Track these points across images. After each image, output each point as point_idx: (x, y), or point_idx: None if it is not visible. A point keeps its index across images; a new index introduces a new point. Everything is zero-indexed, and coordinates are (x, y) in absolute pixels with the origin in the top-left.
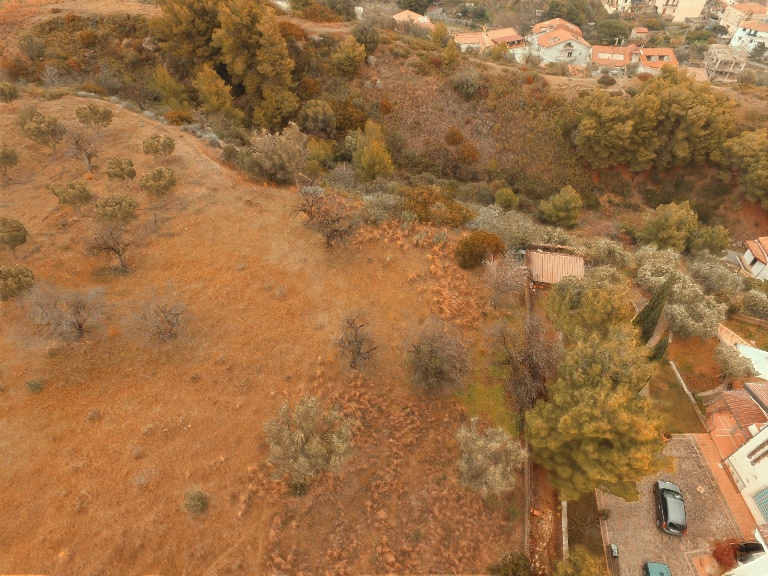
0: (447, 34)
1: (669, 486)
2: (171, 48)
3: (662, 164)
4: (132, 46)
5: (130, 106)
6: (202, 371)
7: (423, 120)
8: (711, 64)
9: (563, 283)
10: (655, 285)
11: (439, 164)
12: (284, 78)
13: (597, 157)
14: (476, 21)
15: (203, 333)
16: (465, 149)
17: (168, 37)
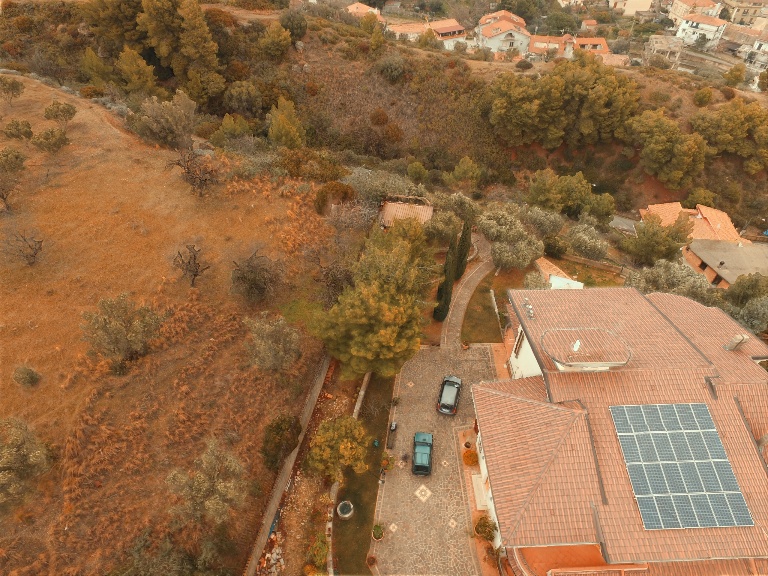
0: (376, 22)
1: (453, 379)
2: (102, 32)
3: (572, 142)
4: (67, 31)
5: (49, 82)
6: (58, 287)
7: (349, 102)
8: (649, 54)
9: None
10: (487, 227)
11: (361, 142)
12: (209, 60)
13: (512, 135)
14: (432, 14)
15: (67, 260)
16: (389, 129)
17: (98, 22)
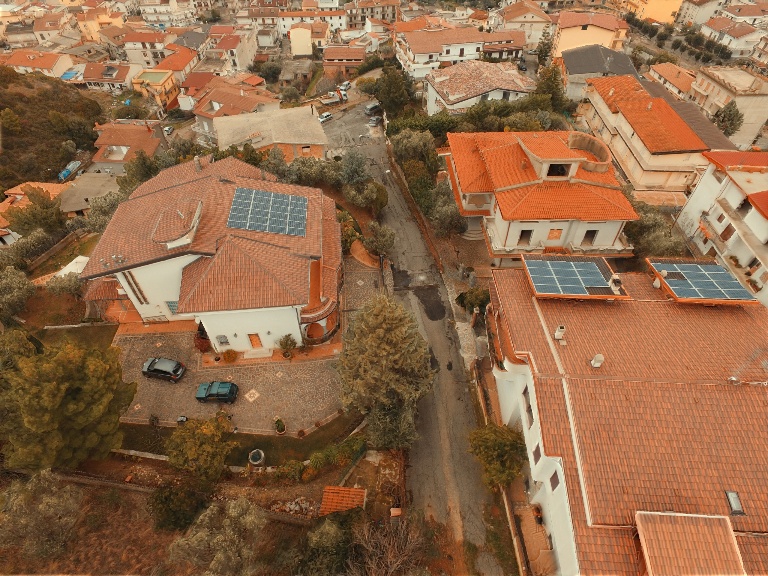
0: None
1: (147, 364)
2: None
3: None
4: None
5: None
6: None
7: None
8: None
9: None
10: None
11: None
12: None
13: None
14: None
15: None
16: None
17: None
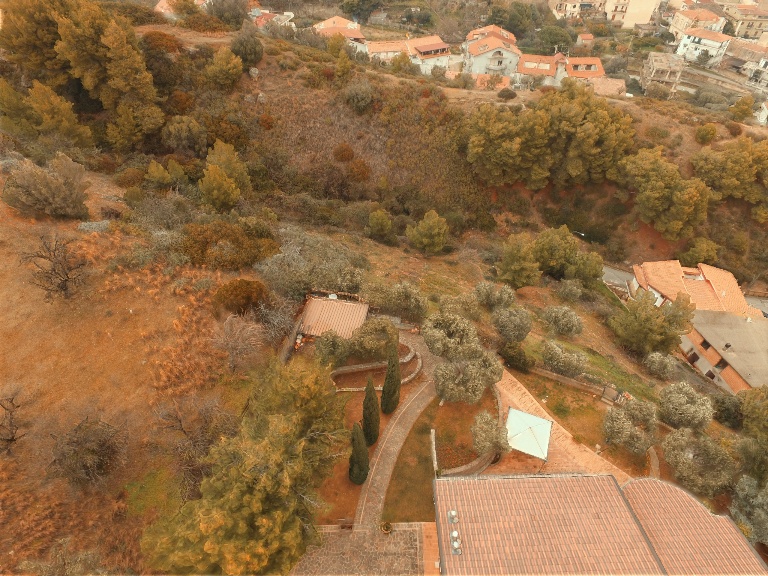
0: (344, 44)
1: None
2: (20, 60)
3: (559, 182)
4: None
5: None
6: None
7: (310, 135)
8: (648, 73)
9: (321, 339)
10: (431, 340)
11: (321, 183)
12: (143, 93)
13: (492, 175)
14: (420, 26)
15: None
16: (354, 166)
17: (14, 49)
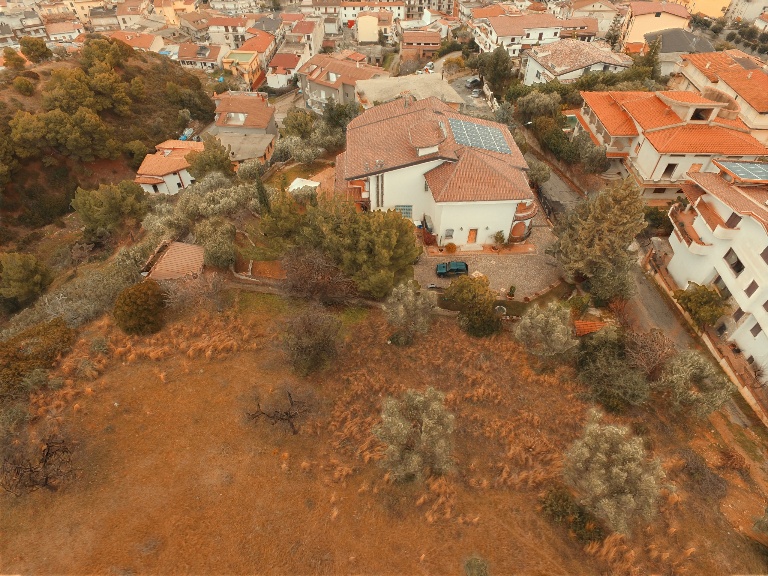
0: None
1: None
2: None
3: None
4: None
5: None
6: None
7: None
8: None
9: (211, 255)
10: (227, 206)
11: None
12: None
13: None
14: None
15: None
16: None
17: None
